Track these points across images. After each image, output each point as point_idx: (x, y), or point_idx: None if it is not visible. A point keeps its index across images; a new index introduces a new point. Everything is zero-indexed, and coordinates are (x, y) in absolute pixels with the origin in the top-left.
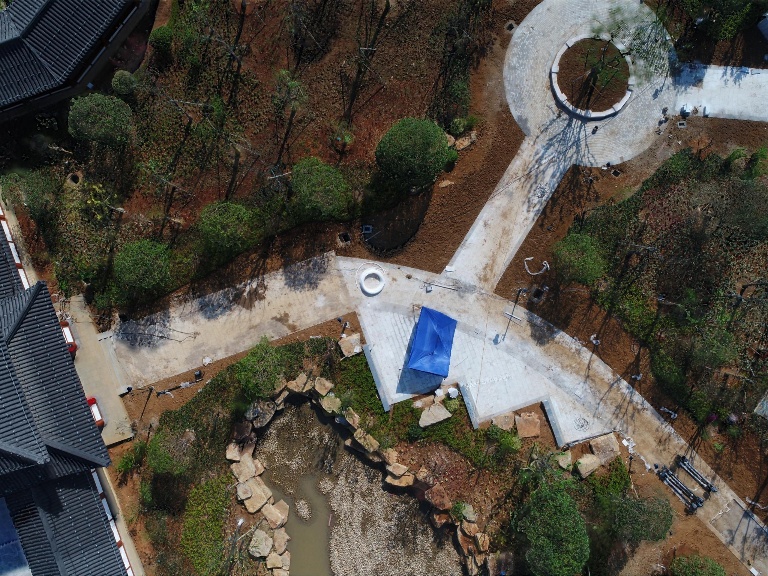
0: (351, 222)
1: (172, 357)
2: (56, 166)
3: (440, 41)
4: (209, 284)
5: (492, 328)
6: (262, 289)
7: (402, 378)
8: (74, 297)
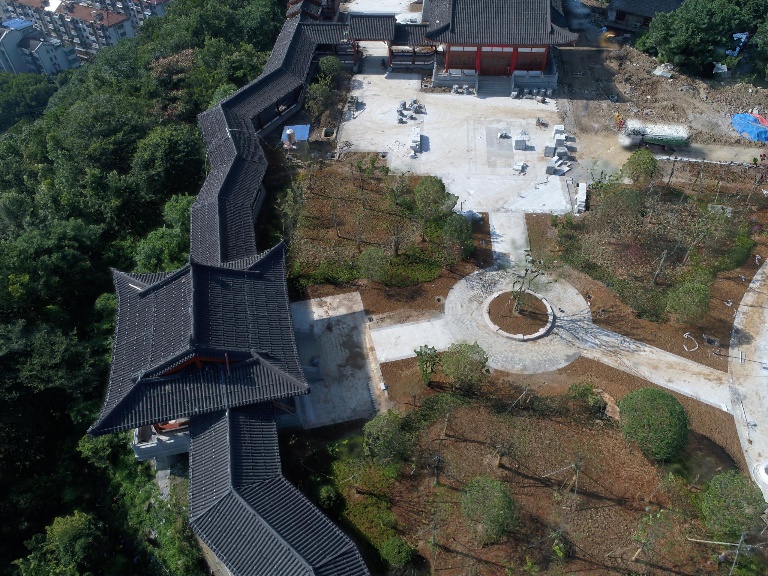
0: None
1: None
2: None
3: (519, 421)
4: None
5: (760, 372)
6: None
7: None
8: None
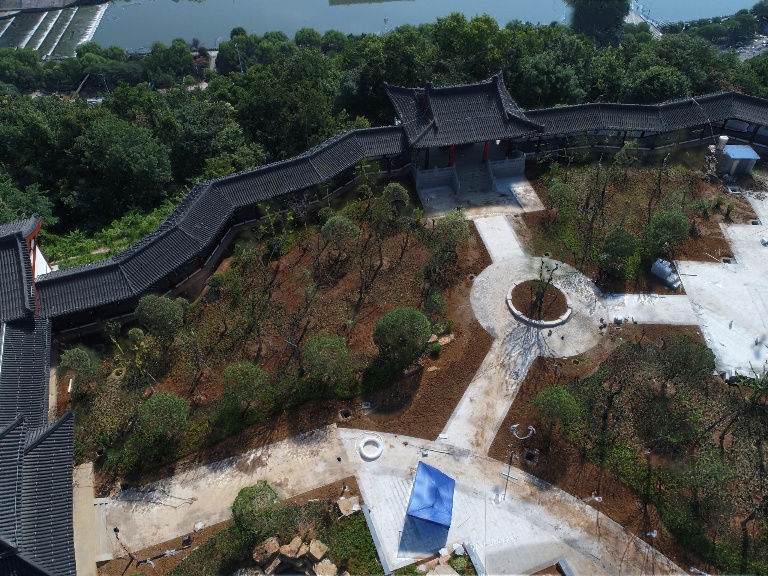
0: (352, 400)
1: (163, 523)
2: (106, 364)
3: (420, 282)
4: (216, 453)
5: (491, 488)
6: (266, 457)
7: (403, 541)
8: (84, 464)
